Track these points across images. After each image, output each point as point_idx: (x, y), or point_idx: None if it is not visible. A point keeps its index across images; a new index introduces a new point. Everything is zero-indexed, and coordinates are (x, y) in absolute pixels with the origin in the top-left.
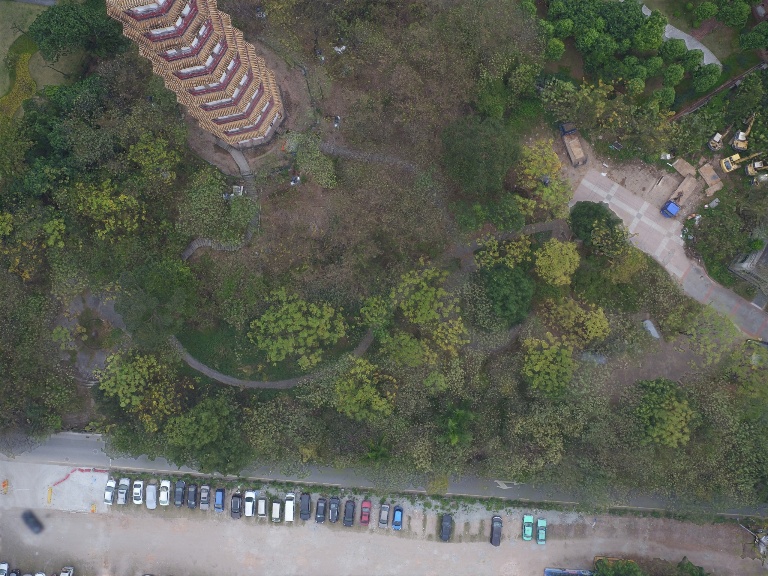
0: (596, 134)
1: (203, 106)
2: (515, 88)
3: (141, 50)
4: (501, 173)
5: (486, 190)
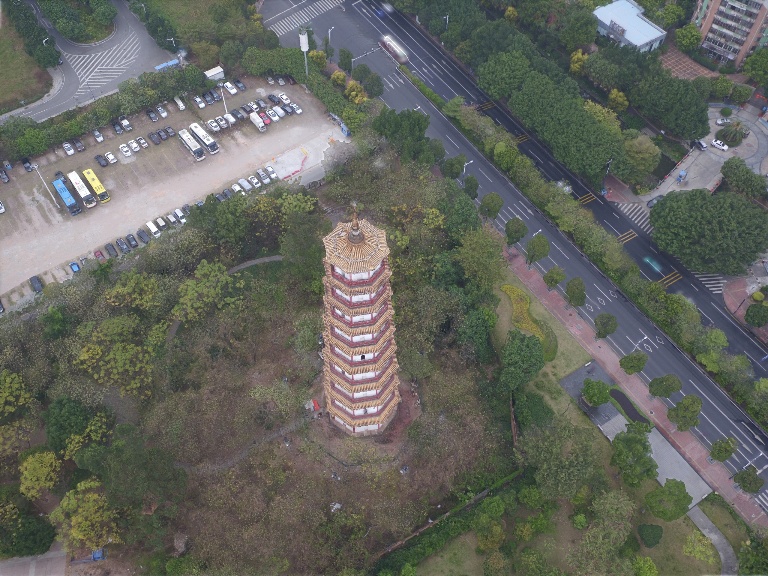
0: None
1: None
2: None
3: None
4: None
5: None
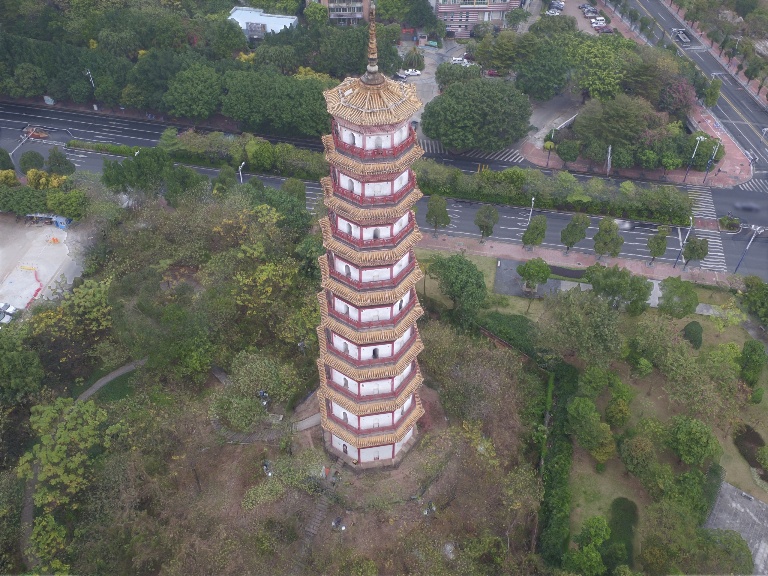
0: None
1: None
2: None
3: None
4: None
5: None
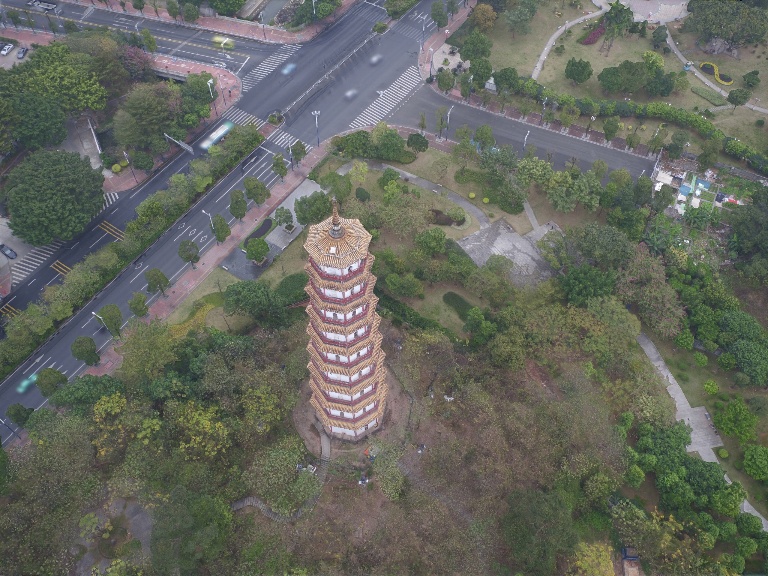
0: (657, 573)
1: (325, 377)
2: (589, 492)
3: (308, 308)
4: (553, 548)
5: (533, 569)
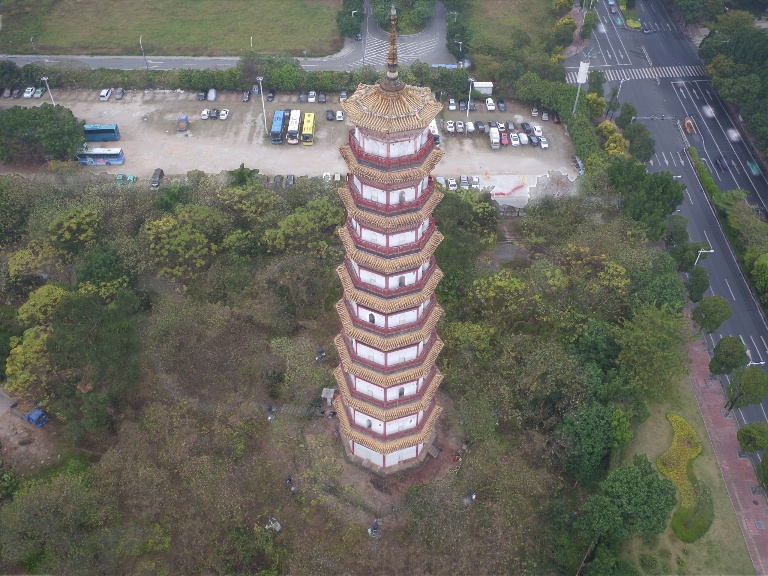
0: None
1: None
2: None
3: None
4: None
5: None
